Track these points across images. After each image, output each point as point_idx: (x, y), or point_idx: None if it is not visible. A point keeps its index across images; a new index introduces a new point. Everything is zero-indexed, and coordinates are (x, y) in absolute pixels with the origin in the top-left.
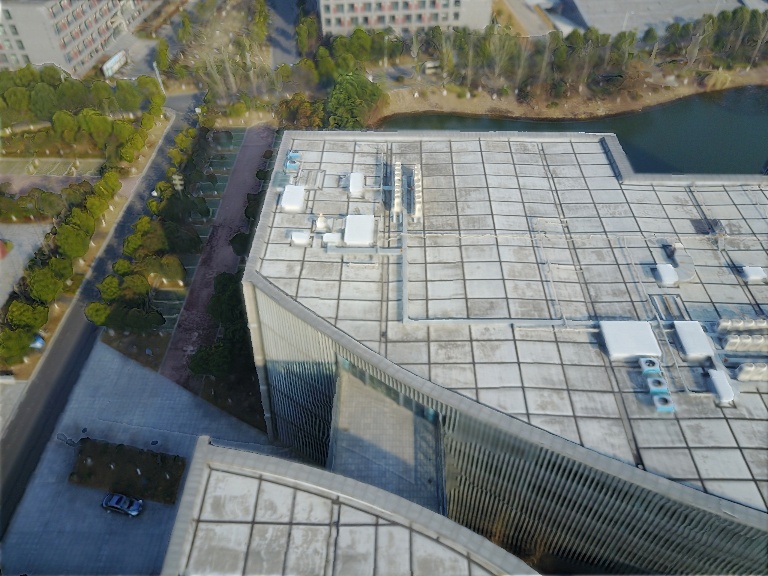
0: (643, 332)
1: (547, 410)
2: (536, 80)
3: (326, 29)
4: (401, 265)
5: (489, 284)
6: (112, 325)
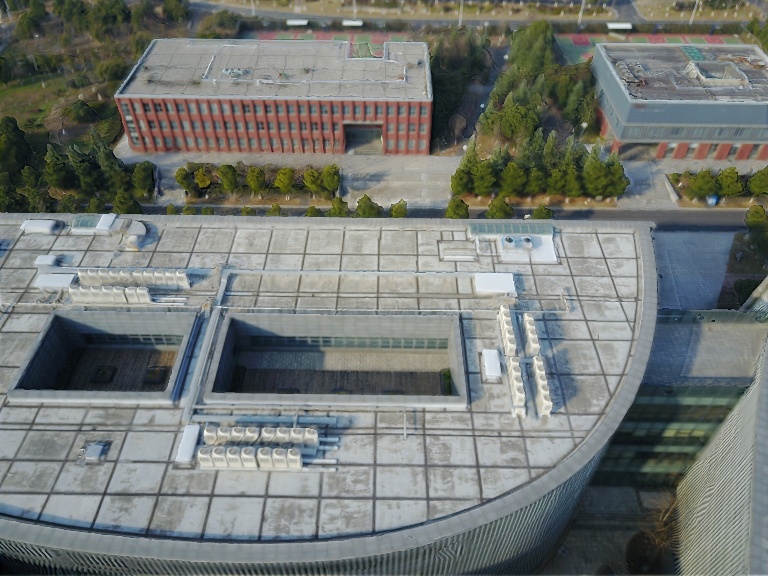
0: None
1: None
2: None
3: None
4: None
5: None
6: (752, 231)
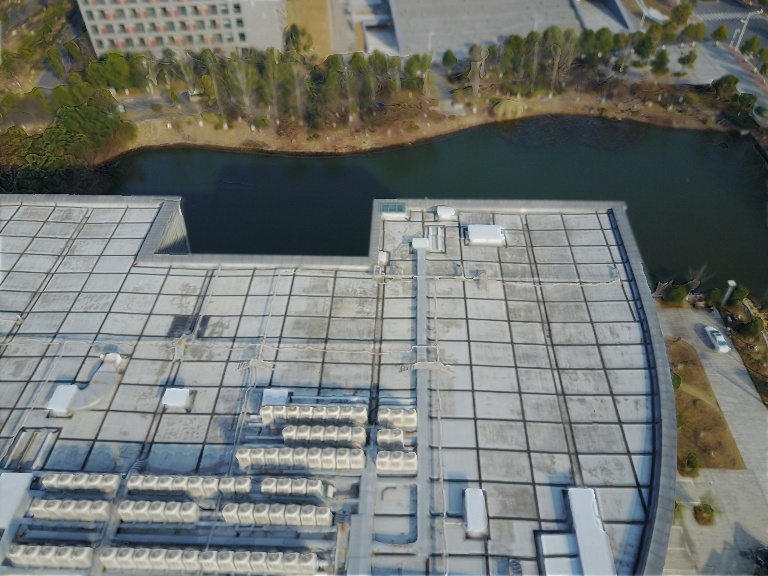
0: None
1: None
2: (296, 110)
3: (100, 51)
4: None
5: None
6: None
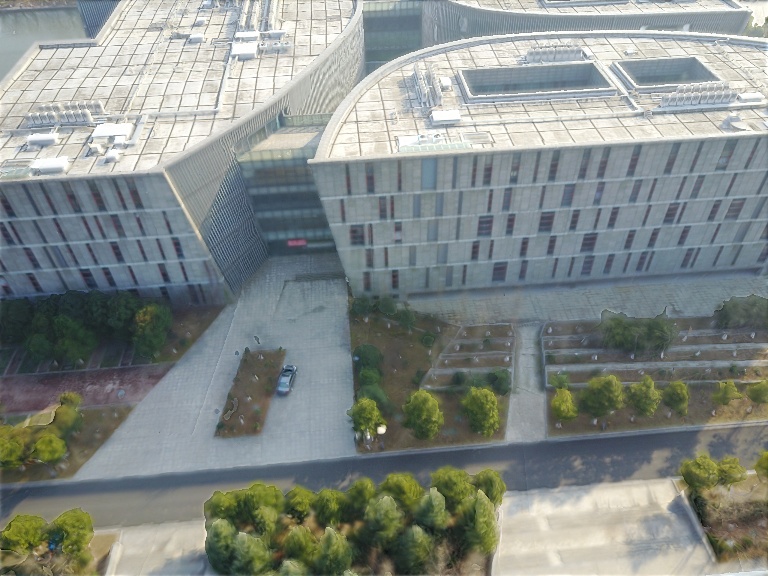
0: None
1: (289, 71)
2: None
3: None
4: (159, 117)
5: (190, 86)
6: None
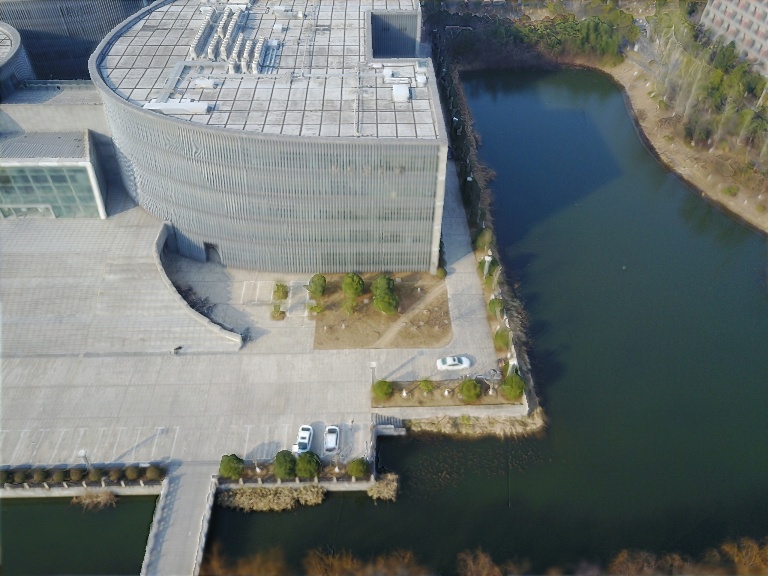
0: (242, 0)
1: None
2: None
3: None
4: None
5: None
6: None
